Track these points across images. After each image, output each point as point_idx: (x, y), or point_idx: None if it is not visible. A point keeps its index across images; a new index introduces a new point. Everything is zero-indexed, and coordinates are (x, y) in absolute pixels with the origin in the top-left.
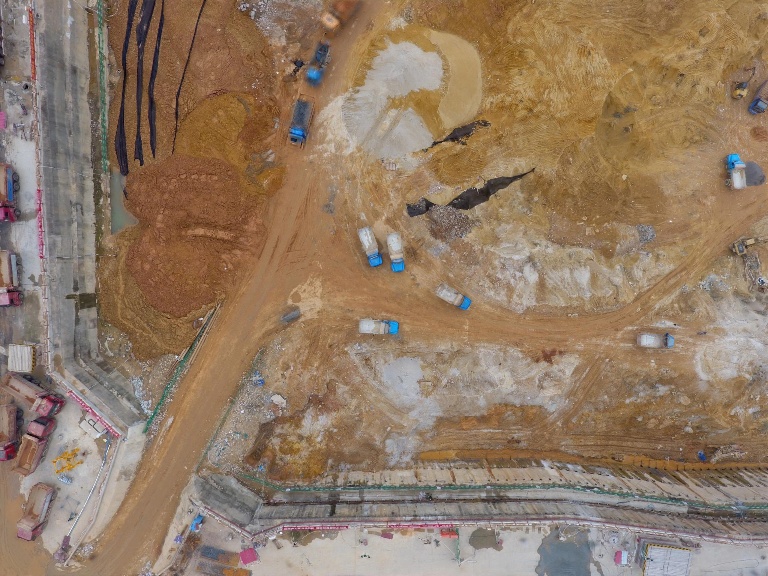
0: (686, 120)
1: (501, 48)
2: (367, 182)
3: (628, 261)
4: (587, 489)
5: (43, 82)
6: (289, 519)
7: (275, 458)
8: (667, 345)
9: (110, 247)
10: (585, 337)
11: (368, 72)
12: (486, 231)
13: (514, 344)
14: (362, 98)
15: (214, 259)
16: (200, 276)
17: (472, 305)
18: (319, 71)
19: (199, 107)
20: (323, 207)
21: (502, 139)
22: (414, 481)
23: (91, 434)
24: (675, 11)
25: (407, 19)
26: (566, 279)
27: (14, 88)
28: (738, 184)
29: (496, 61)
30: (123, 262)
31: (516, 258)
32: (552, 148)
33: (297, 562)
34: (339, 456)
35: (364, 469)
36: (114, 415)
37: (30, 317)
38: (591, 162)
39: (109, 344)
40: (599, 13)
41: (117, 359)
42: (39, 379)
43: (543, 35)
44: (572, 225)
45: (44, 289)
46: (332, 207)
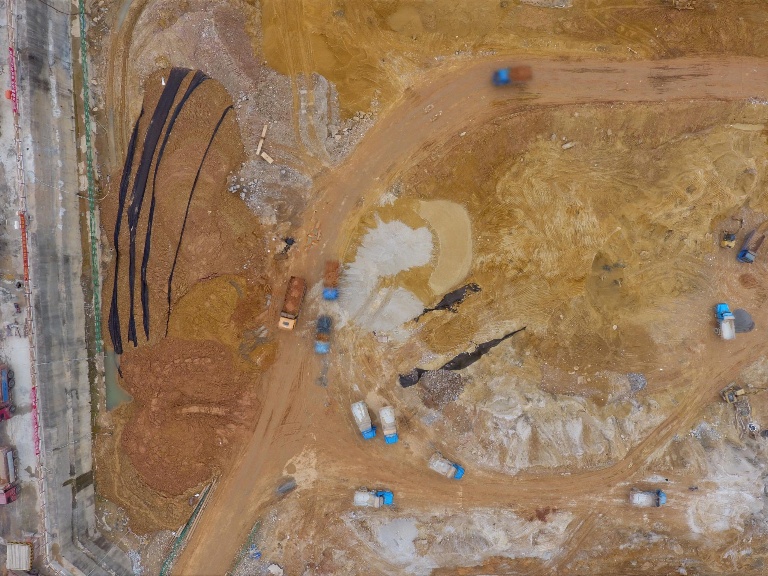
0: (675, 272)
1: (490, 208)
2: (359, 354)
3: (620, 410)
4: None
5: (36, 281)
6: None
7: None
8: (659, 505)
9: (106, 425)
10: (578, 494)
11: (358, 249)
12: (479, 388)
13: (508, 505)
14: (353, 275)
15: (209, 435)
16: (195, 456)
17: (466, 472)
18: (310, 249)
19: (191, 291)
20: (316, 380)
21: (493, 304)
22: None
23: None
24: (663, 161)
25: (396, 194)
26: (559, 434)
27: (7, 286)
28: (727, 334)
29: (486, 221)
30: (119, 441)
31: (509, 418)
32: (542, 308)
33: None
34: None
35: None
36: None
37: (27, 507)
38: (581, 316)
39: (106, 519)
40: (587, 167)
41: (115, 533)
42: (38, 567)
43: (532, 195)
44: (564, 374)
45: (41, 483)
46: (325, 380)
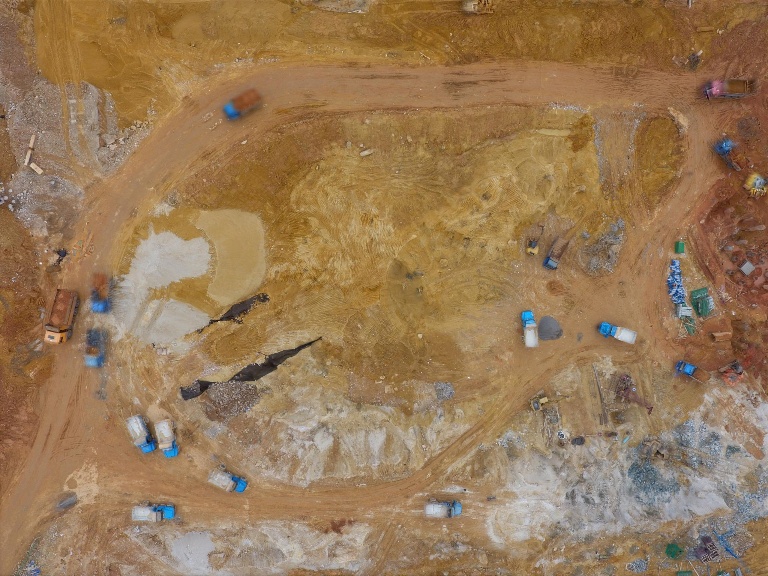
0: (478, 279)
1: (284, 217)
2: (139, 367)
3: (426, 420)
4: None
5: None
6: None
7: None
8: (451, 516)
9: None
10: (375, 505)
11: (132, 260)
12: (277, 399)
13: (300, 518)
14: (126, 287)
15: None
16: None
17: (252, 484)
18: (83, 260)
19: None
20: (95, 394)
21: (281, 314)
22: None
23: None
24: (468, 168)
25: (172, 204)
26: (358, 445)
27: None
28: (532, 342)
29: (280, 230)
30: None
31: (302, 430)
32: (336, 318)
33: None
34: None
35: None
36: None
37: None
38: (382, 325)
39: None
40: (388, 174)
41: None
42: None
43: (326, 203)
44: (371, 384)
45: None
46: (104, 393)
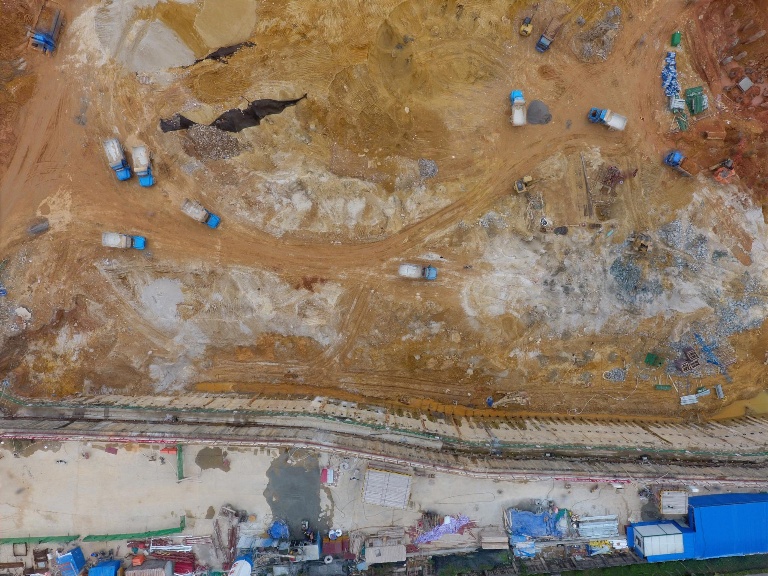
0: (469, 54)
1: None
2: (120, 95)
3: (407, 195)
4: (337, 419)
5: None
6: (12, 429)
7: (28, 375)
8: (425, 275)
9: None
10: (349, 266)
11: None
12: (258, 156)
13: (272, 268)
14: (114, 9)
15: None
16: None
17: (225, 225)
18: None
19: None
20: (75, 118)
21: (267, 60)
22: (164, 404)
23: None
24: None
25: None
26: (336, 208)
27: None
28: (520, 121)
29: None
30: None
31: (280, 182)
32: (323, 73)
33: (18, 474)
34: (98, 378)
35: (126, 394)
36: None
37: None
38: (369, 92)
39: None
40: None
41: None
42: None
43: None
44: (354, 157)
45: None
46: (84, 119)
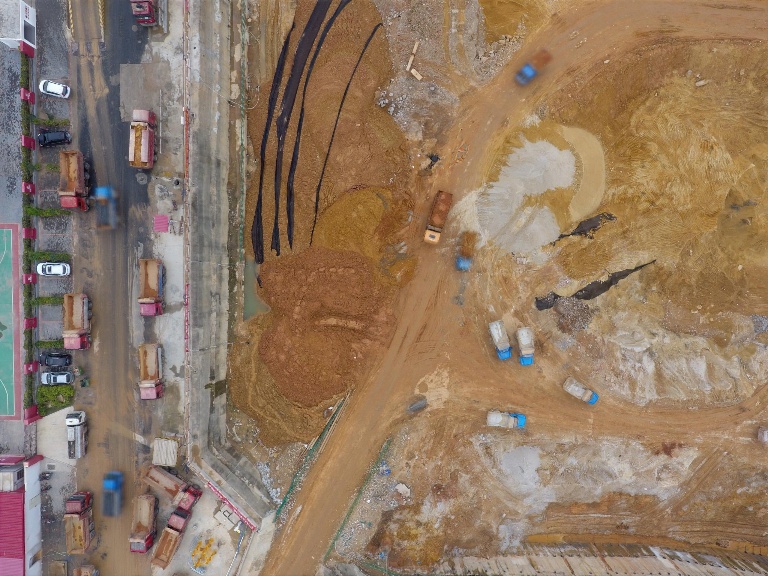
0: None
1: (624, 141)
2: (497, 275)
3: (743, 351)
4: None
5: (195, 179)
6: None
7: (392, 544)
8: None
9: (242, 334)
10: (704, 430)
11: (503, 168)
12: (605, 320)
13: (635, 437)
14: (497, 194)
15: (345, 349)
16: (333, 367)
17: (597, 399)
18: (454, 166)
19: (339, 201)
20: (453, 299)
21: (628, 233)
22: (533, 572)
23: (226, 525)
24: None
25: (541, 116)
26: (684, 370)
27: (165, 184)
28: None
29: (619, 153)
30: (256, 350)
31: (638, 350)
32: (674, 241)
33: None
34: (454, 542)
35: (477, 554)
36: (248, 506)
37: (170, 407)
38: (710, 253)
39: (237, 429)
40: (718, 106)
41: (244, 444)
42: (176, 469)
43: (666, 129)
44: (686, 313)
45: (187, 382)
46: (462, 299)
